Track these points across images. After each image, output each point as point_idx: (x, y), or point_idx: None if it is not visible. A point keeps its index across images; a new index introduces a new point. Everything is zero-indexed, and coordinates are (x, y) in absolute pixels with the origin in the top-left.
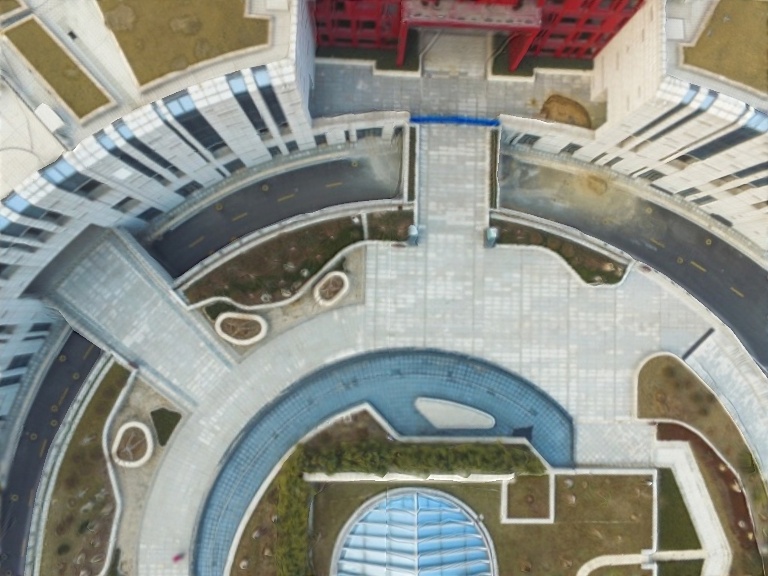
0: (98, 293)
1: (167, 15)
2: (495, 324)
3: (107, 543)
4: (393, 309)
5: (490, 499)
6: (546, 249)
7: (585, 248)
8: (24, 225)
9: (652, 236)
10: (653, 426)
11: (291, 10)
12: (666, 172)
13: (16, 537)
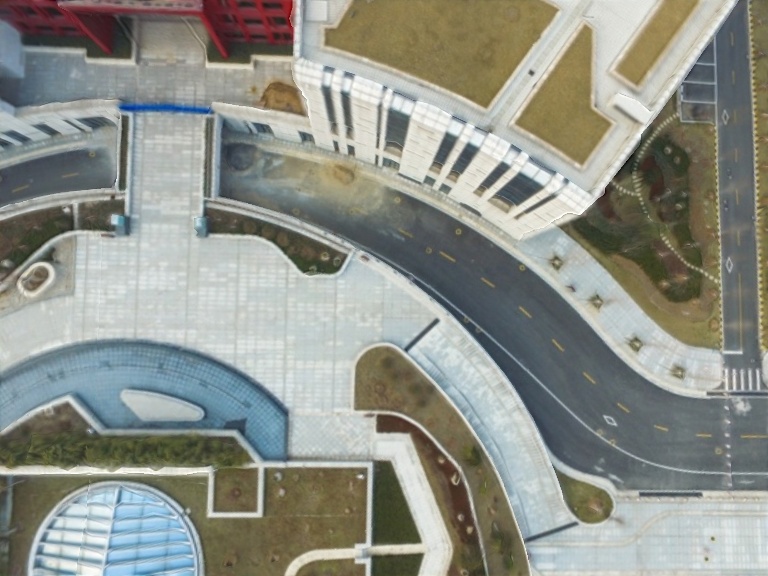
0: None
1: None
2: (209, 315)
3: None
4: (103, 300)
5: (198, 493)
6: (261, 238)
7: (305, 237)
8: None
9: (400, 226)
10: (372, 418)
11: None
12: (396, 160)
13: None
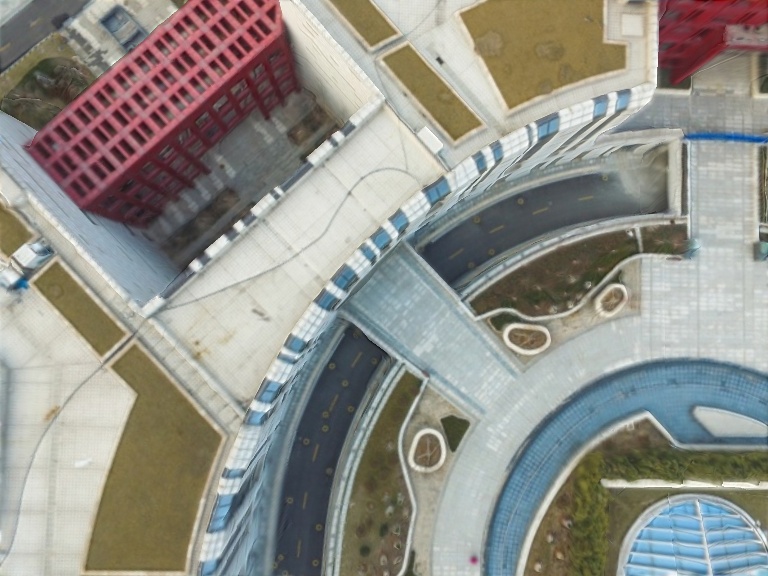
0: (389, 304)
1: (532, 41)
2: (765, 335)
3: (404, 545)
4: (668, 320)
5: (766, 506)
6: None
7: None
8: None
9: None
10: None
11: (651, 36)
12: None
13: (292, 539)
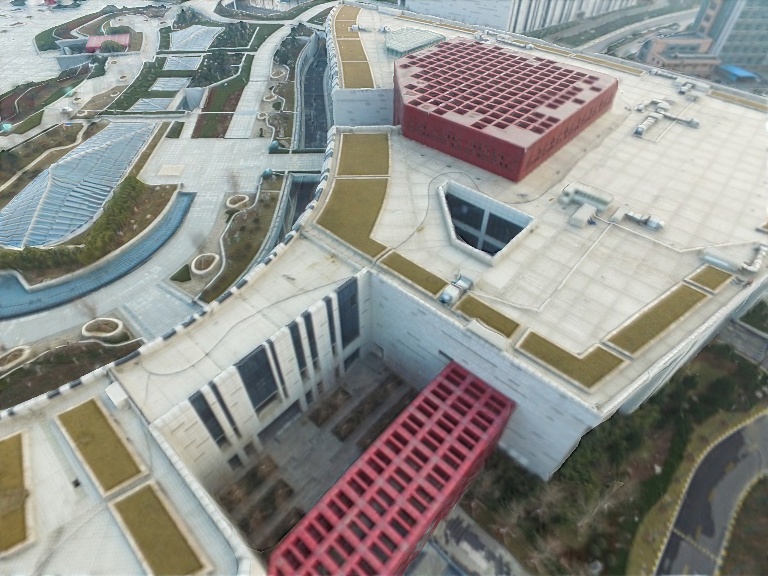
0: None
1: None
2: None
3: None
4: None
5: None
6: None
7: None
8: None
9: None
10: None
11: None
12: None
13: None
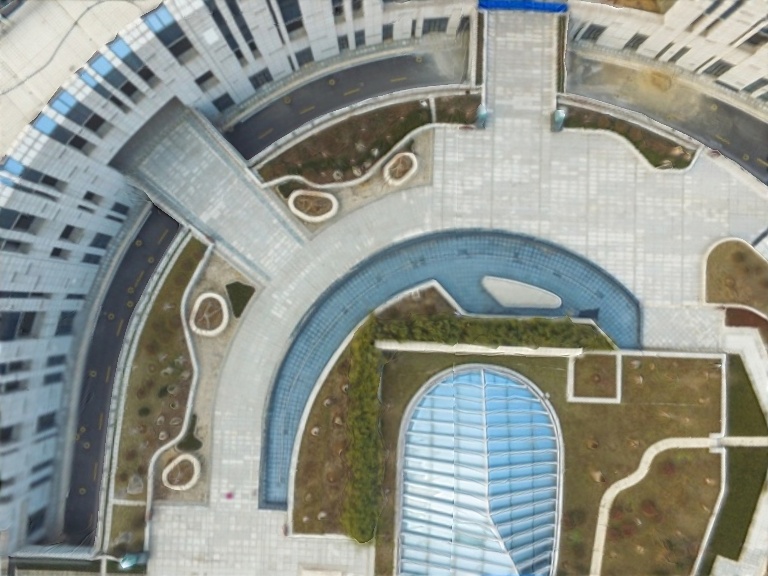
0: (177, 171)
1: None
2: (561, 207)
3: (184, 408)
4: (460, 191)
5: (556, 378)
6: (613, 133)
7: (652, 134)
8: (123, 75)
9: (717, 132)
10: (721, 311)
11: None
12: (735, 61)
13: (94, 411)
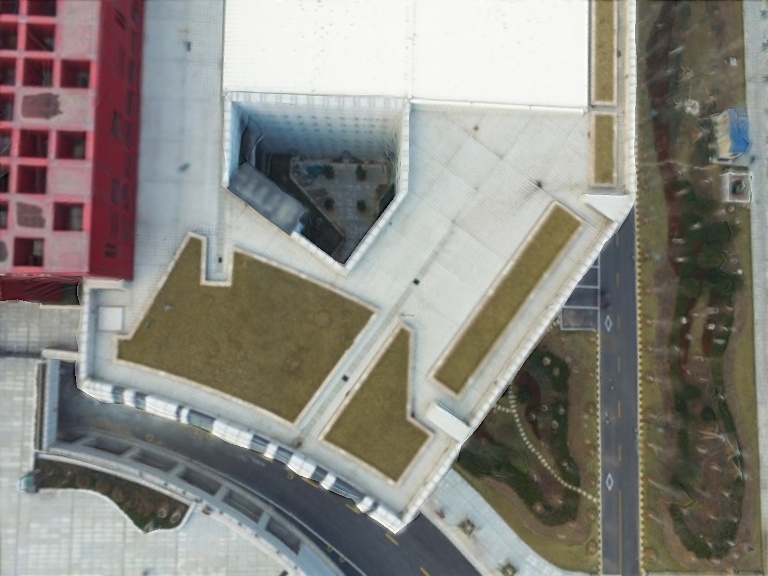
0: None
1: None
2: (40, 574)
3: None
4: None
5: None
6: (96, 493)
7: (144, 488)
8: None
9: None
10: None
11: None
12: None
13: None
